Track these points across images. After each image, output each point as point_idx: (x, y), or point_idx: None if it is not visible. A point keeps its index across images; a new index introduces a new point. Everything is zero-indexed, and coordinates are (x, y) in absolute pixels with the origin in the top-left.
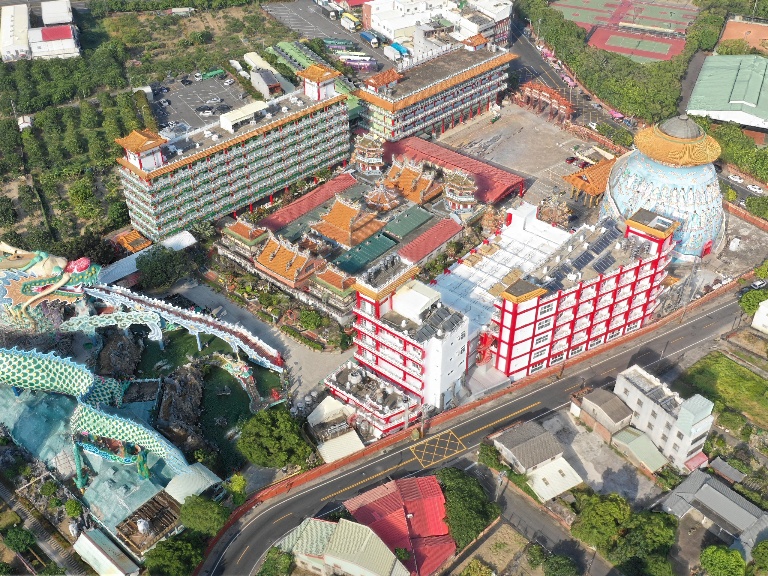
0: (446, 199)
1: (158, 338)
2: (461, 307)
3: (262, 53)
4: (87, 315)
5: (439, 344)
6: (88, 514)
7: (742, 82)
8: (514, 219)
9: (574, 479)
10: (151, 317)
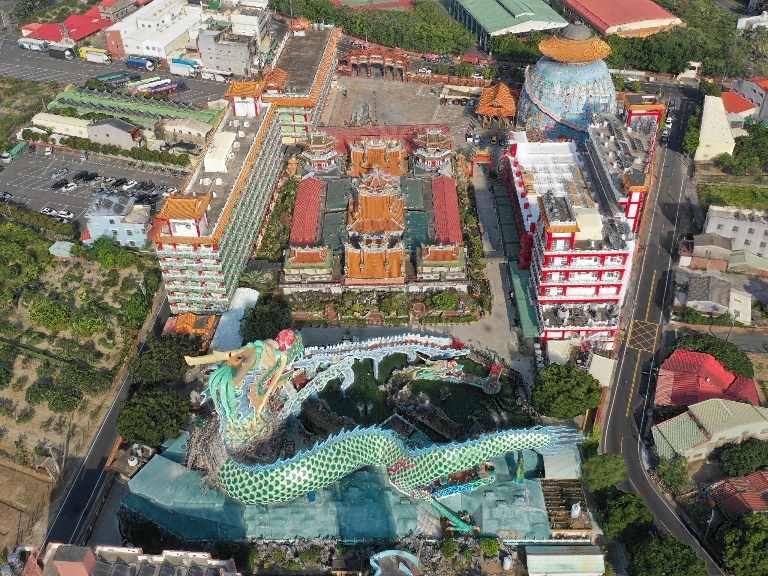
0: None
1: None
2: None
3: (52, 111)
4: (296, 392)
5: (633, 245)
6: (502, 543)
7: (505, 0)
8: (519, 147)
9: (746, 300)
10: (347, 363)
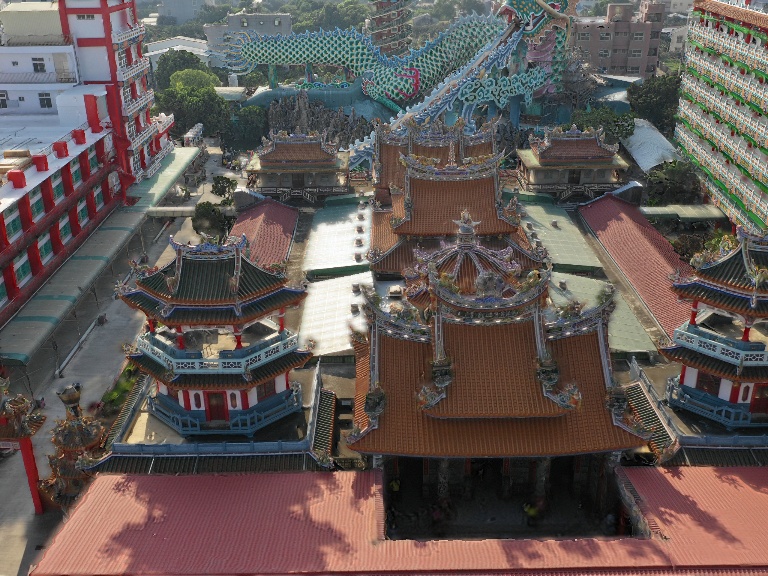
0: None
1: None
2: None
3: None
4: None
5: None
6: None
7: None
8: None
9: None
10: None
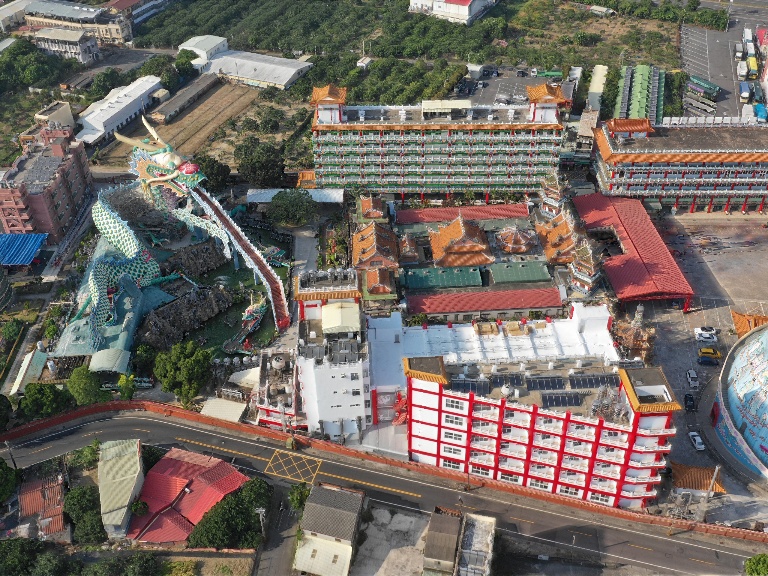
0: (569, 268)
1: (229, 256)
2: None
3: (612, 69)
4: (189, 211)
5: None
6: (56, 342)
7: None
8: (574, 315)
9: (339, 572)
10: (224, 236)
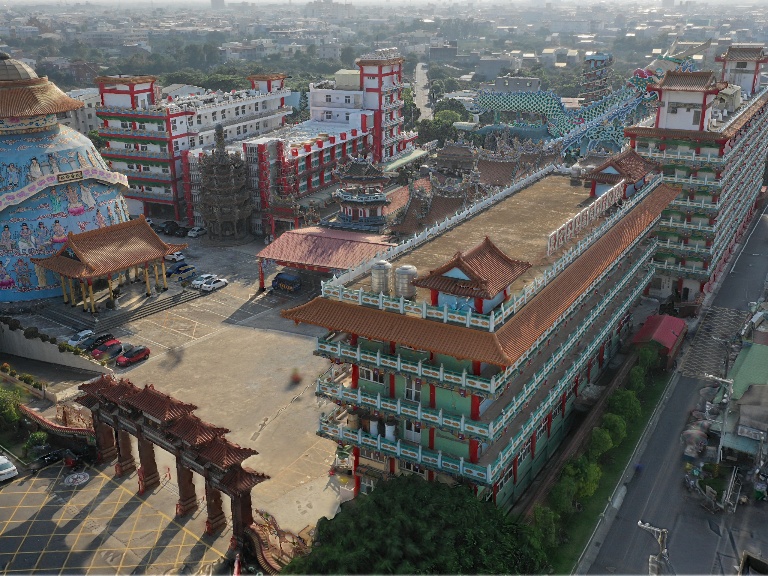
0: None
1: None
2: None
3: None
4: None
5: None
6: None
7: None
8: None
9: None
10: None
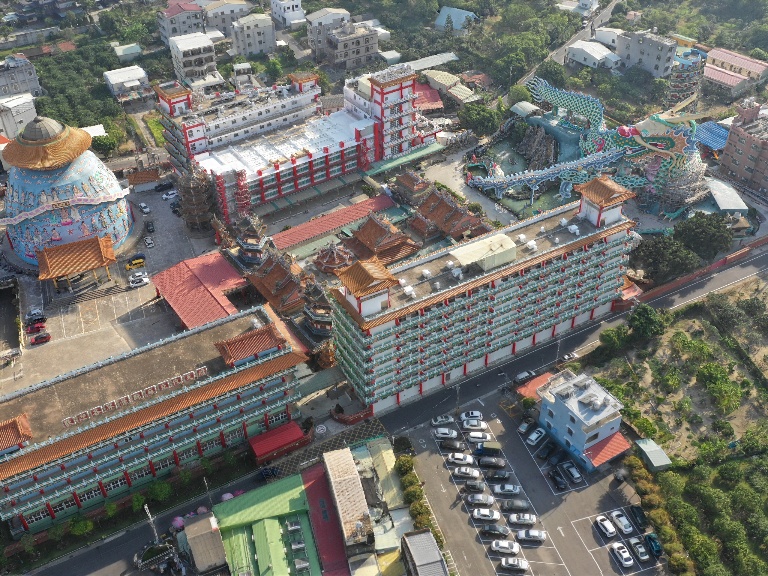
0: None
1: None
2: (332, 130)
3: None
4: None
5: None
6: None
7: None
8: None
9: None
10: None
